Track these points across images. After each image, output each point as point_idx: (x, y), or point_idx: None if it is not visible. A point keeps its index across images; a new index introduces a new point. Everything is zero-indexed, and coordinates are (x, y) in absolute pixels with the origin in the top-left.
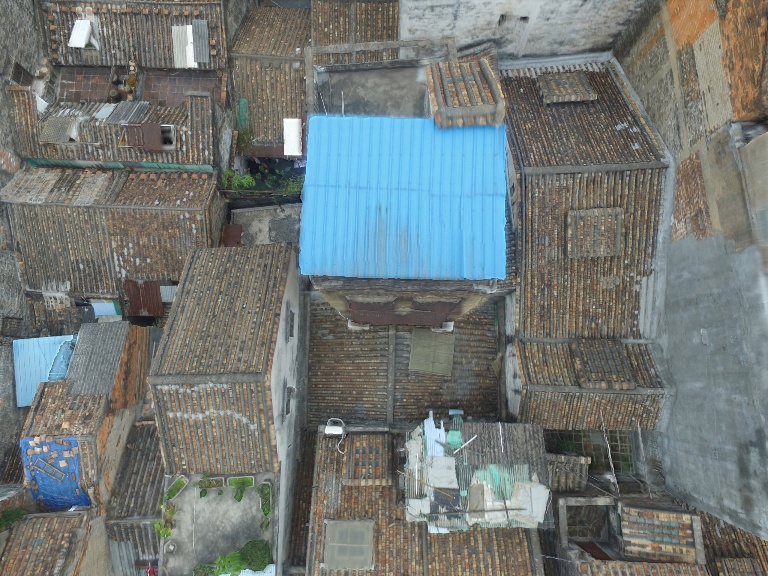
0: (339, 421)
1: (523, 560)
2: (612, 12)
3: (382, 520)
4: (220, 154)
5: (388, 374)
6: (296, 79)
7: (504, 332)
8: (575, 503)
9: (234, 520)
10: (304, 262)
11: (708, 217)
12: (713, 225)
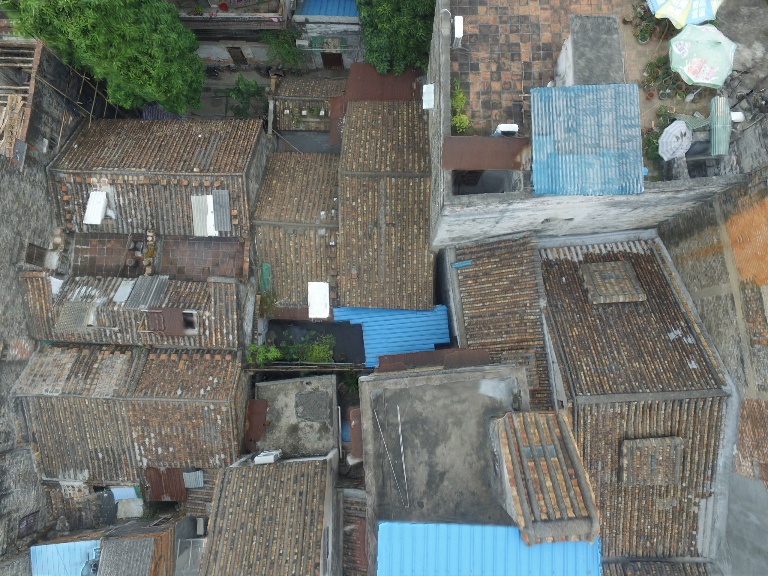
0: None
1: None
2: (662, 211)
3: None
4: (244, 331)
5: None
6: (321, 244)
7: None
8: None
9: None
10: None
11: None
12: None
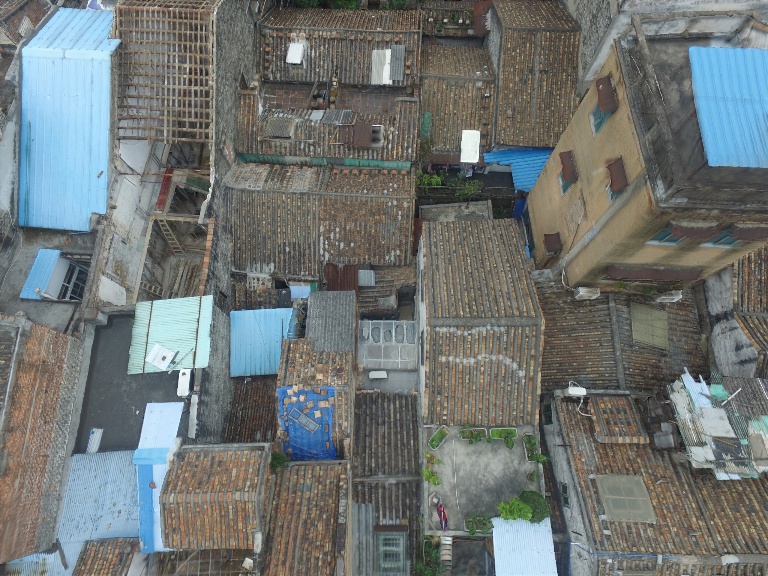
0: (577, 385)
1: None
2: None
3: (647, 478)
4: None
5: (614, 343)
6: (477, 96)
7: (707, 313)
8: None
9: (496, 474)
10: (712, 154)
11: None
12: None
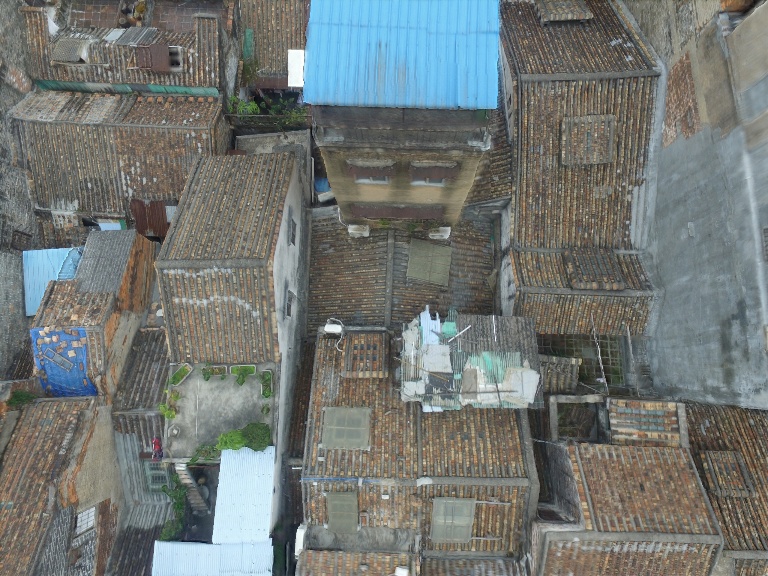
0: (338, 322)
1: (514, 445)
2: None
3: (378, 409)
4: (226, 79)
5: (386, 280)
6: (301, 10)
7: (500, 248)
8: (565, 400)
9: (236, 407)
10: (308, 92)
11: (696, 113)
12: (701, 119)
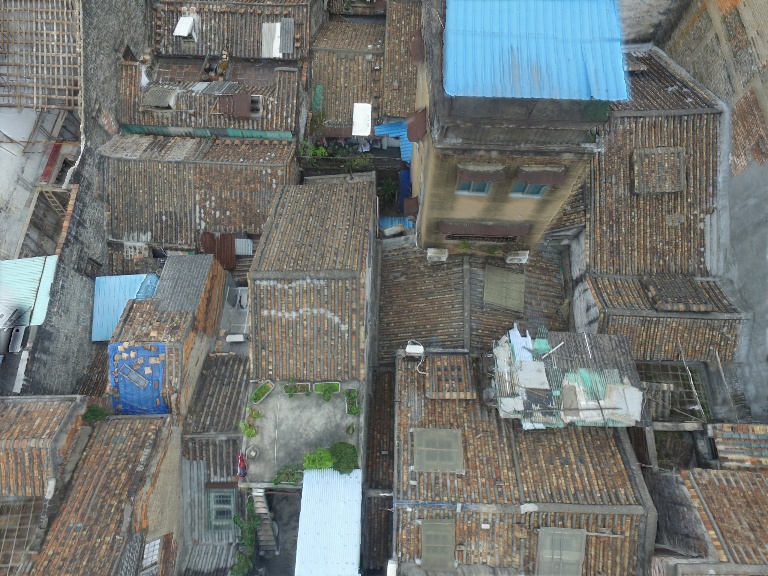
0: (418, 344)
1: (619, 471)
2: (655, 0)
3: (468, 432)
4: (299, 125)
5: (464, 304)
6: (368, 69)
7: (570, 278)
8: (662, 428)
9: (318, 428)
10: (448, 84)
11: None
12: None
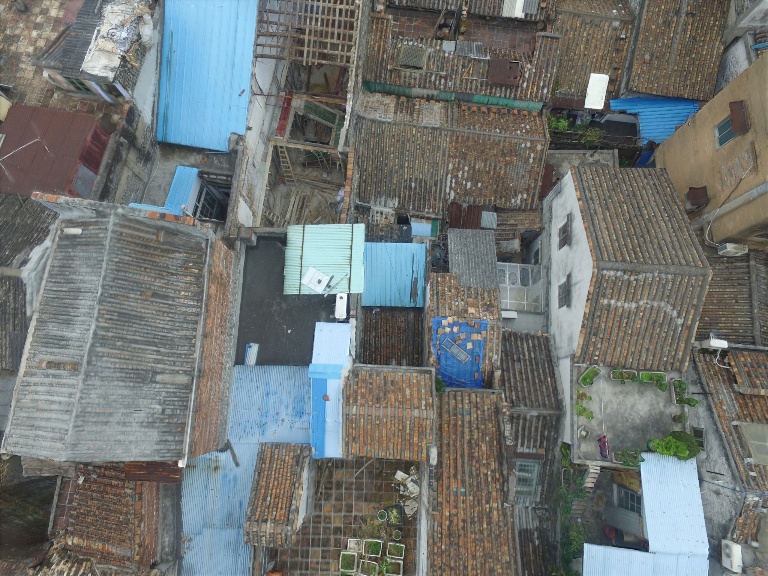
0: (716, 338)
1: None
2: None
3: None
4: None
5: (753, 301)
6: (612, 37)
7: None
8: None
9: (642, 414)
10: None
11: None
12: None
